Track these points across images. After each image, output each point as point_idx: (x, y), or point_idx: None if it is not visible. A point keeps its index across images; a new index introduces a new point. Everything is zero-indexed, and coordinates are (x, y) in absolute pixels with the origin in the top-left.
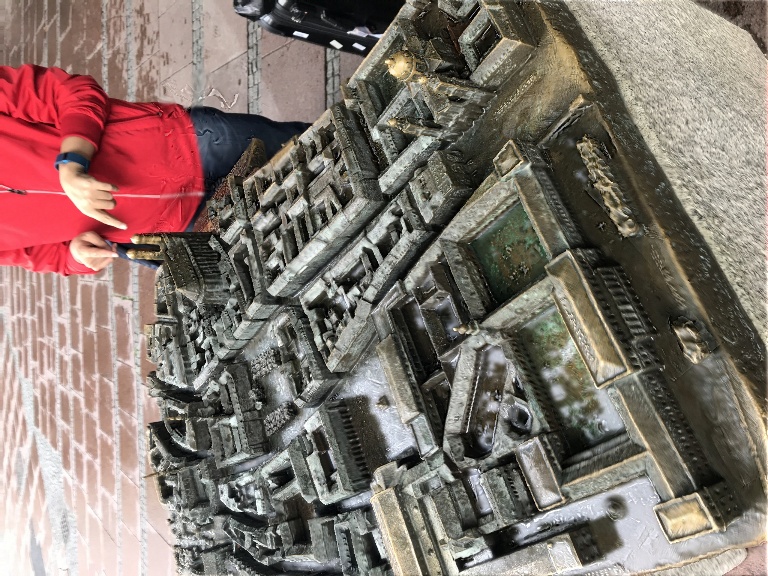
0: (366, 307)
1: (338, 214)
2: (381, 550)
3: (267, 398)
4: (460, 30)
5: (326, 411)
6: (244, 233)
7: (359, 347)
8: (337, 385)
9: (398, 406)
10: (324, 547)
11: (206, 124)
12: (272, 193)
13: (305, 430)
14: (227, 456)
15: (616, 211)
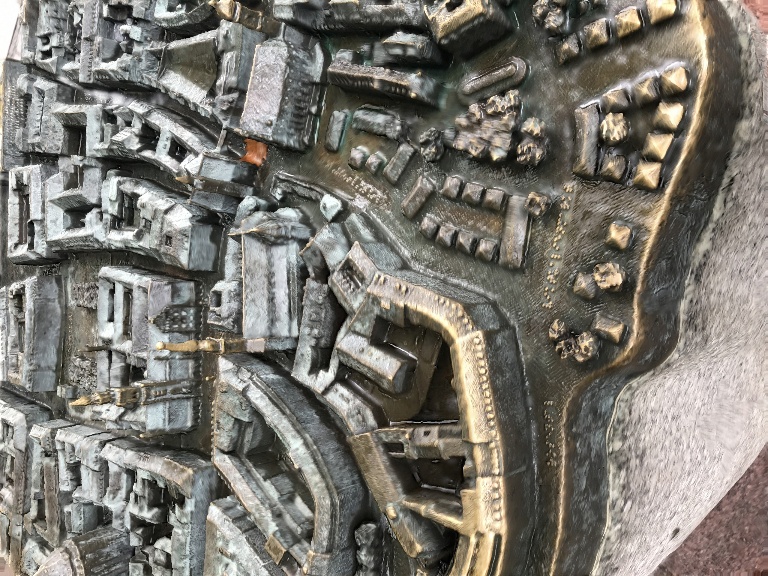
0: None
1: None
2: None
3: None
4: None
5: None
6: None
7: None
8: None
9: None
10: None
11: None
12: None
13: None
14: (134, 290)
15: None
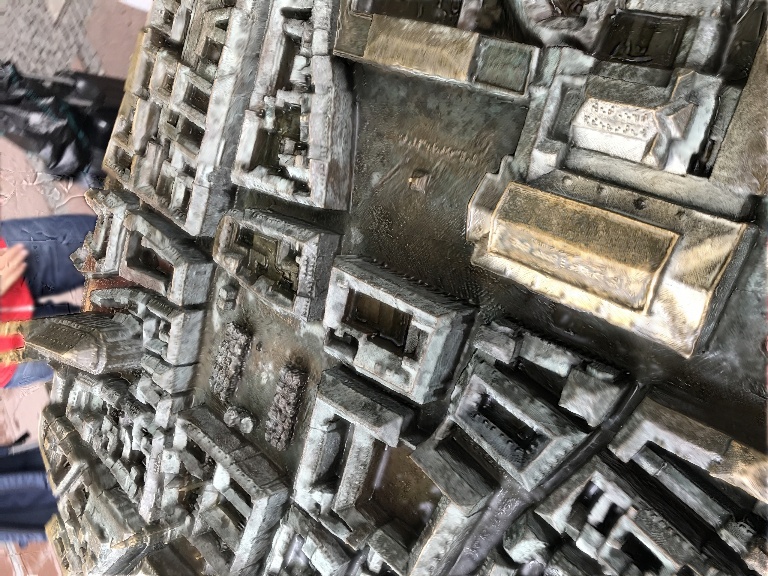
0: (323, 64)
1: (231, 16)
2: (554, 363)
3: (255, 414)
4: None
5: (345, 261)
6: (127, 214)
7: (343, 146)
8: (341, 251)
9: (442, 67)
10: (461, 480)
11: (45, 231)
12: (142, 120)
13: (329, 334)
14: (234, 547)
15: None
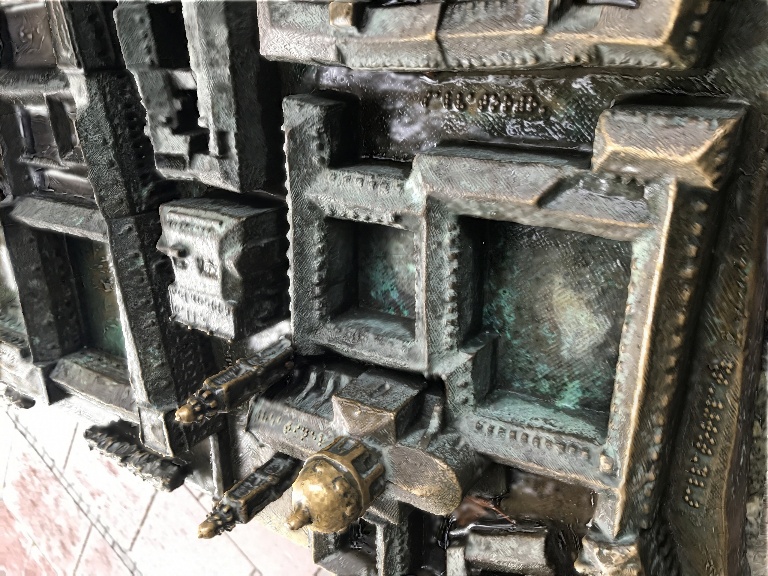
0: None
1: None
2: None
3: None
4: (469, 505)
5: None
6: None
7: None
8: None
9: None
10: None
11: None
12: None
13: None
14: None
15: (97, 449)
